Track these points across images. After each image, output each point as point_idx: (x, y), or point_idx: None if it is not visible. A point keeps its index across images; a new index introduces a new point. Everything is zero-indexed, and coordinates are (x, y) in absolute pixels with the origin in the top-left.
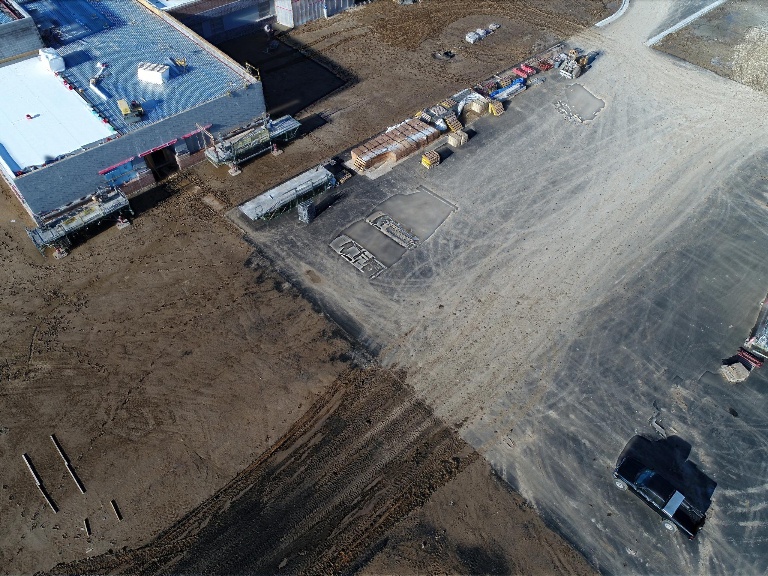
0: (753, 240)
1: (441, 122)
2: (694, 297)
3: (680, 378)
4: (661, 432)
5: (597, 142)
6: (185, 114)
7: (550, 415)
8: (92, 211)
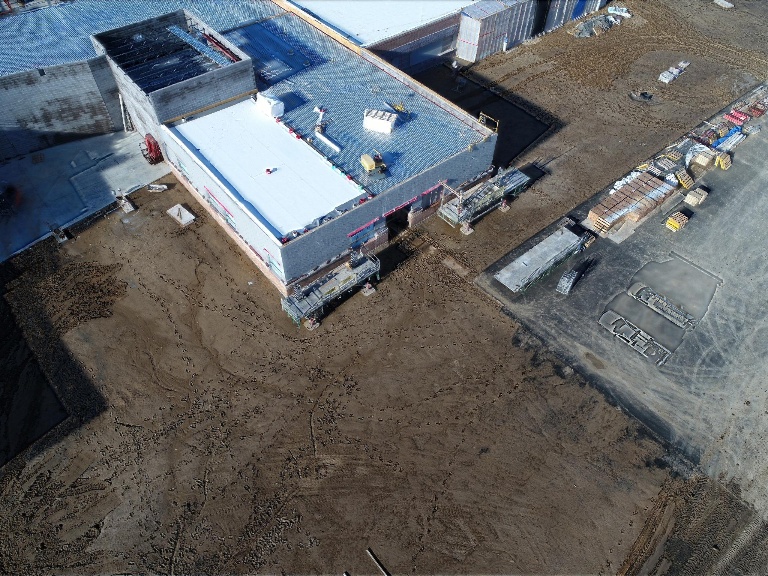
0: None
1: (672, 177)
2: None
3: None
4: None
5: None
6: (430, 171)
7: None
8: (349, 280)
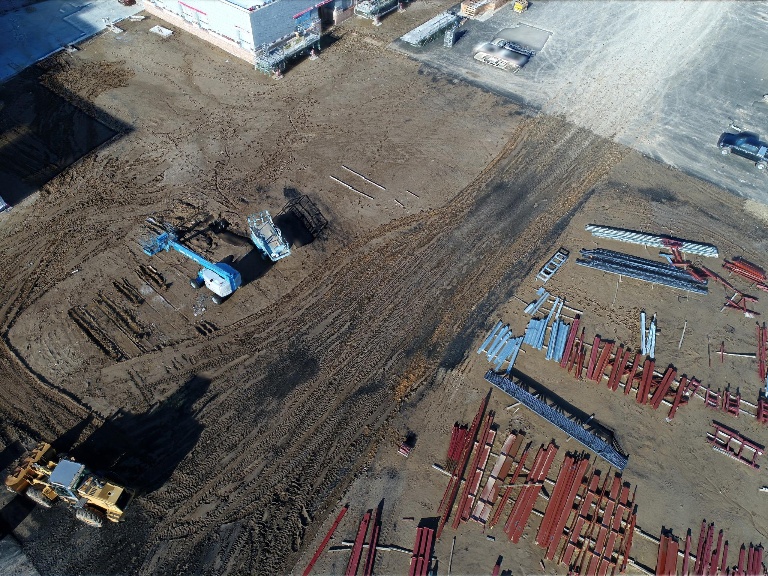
0: (760, 37)
1: None
2: (733, 67)
3: (740, 105)
4: (739, 130)
5: None
6: None
7: (667, 128)
8: (300, 41)
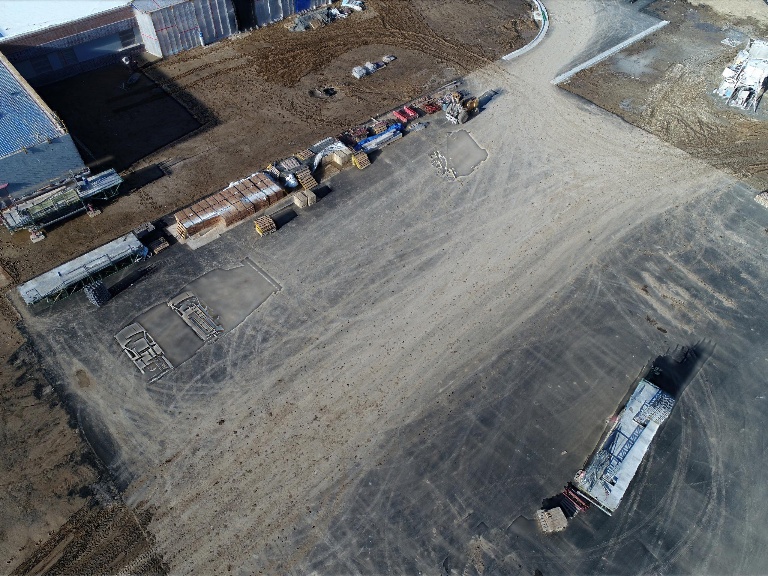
0: (616, 335)
1: (290, 178)
2: (529, 412)
3: (485, 526)
4: None
5: (466, 204)
6: None
7: None
8: None
